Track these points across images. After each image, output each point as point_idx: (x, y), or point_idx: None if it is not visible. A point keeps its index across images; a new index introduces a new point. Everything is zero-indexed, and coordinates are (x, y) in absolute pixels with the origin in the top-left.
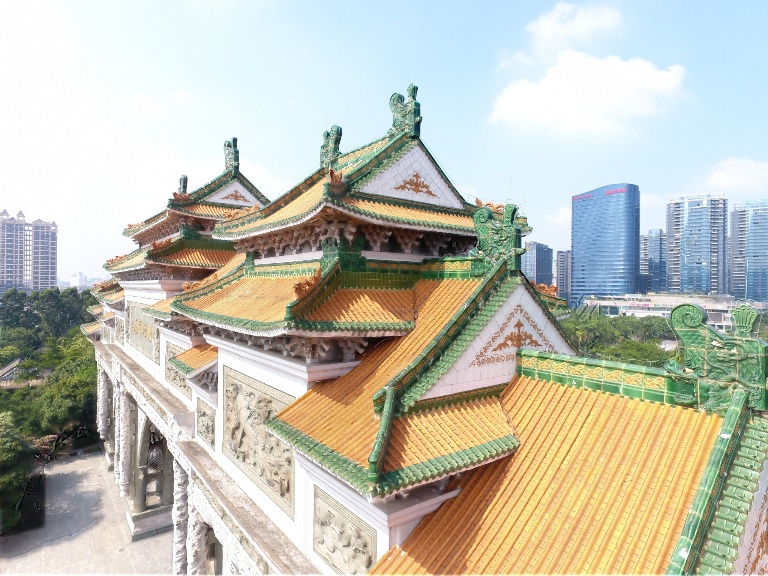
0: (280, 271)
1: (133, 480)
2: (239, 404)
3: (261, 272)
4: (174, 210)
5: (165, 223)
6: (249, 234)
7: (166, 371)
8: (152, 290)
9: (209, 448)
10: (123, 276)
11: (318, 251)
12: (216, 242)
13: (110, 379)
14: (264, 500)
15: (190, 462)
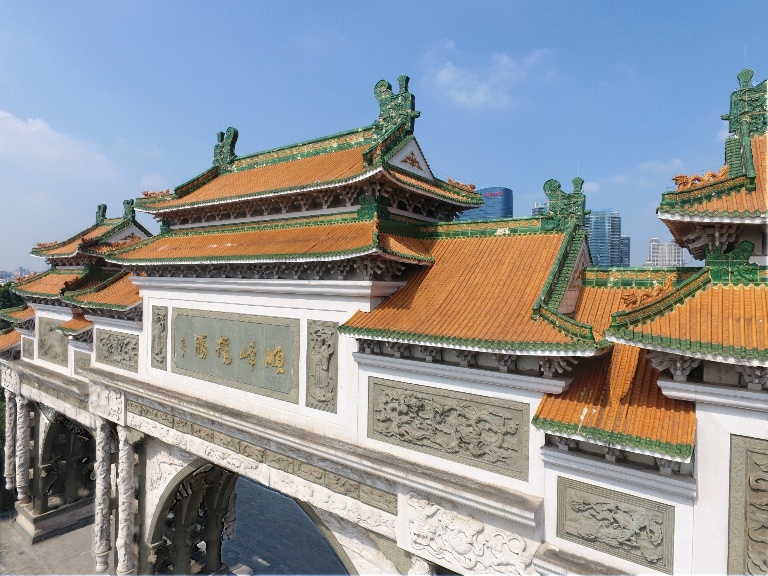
0: None
1: (137, 564)
2: None
3: None
4: (385, 171)
5: (316, 192)
6: None
7: (371, 423)
8: (300, 295)
9: (637, 566)
10: (172, 270)
11: None
12: (403, 225)
13: (74, 418)
14: None
15: None
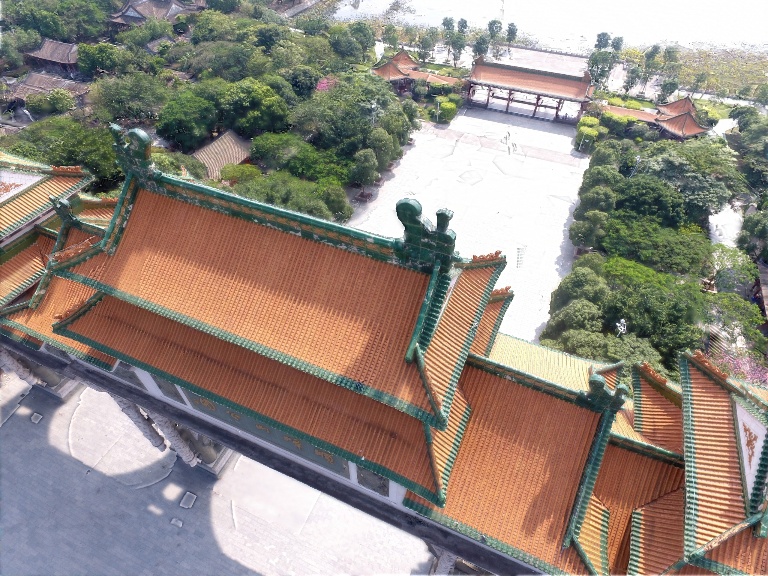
0: None
1: None
2: None
3: None
4: None
5: None
6: None
7: None
8: None
9: None
10: None
11: None
12: None
13: None
14: None
15: None
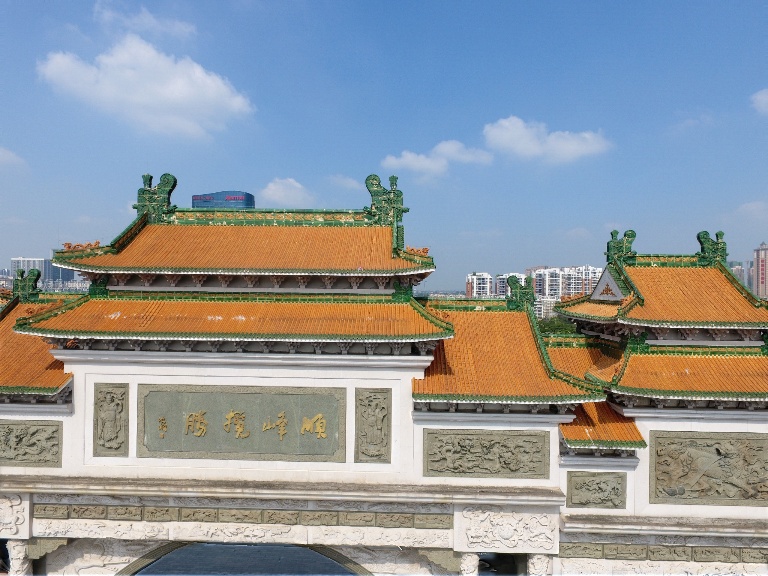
0: (703, 352)
1: None
2: (695, 455)
3: (667, 351)
4: None
5: (355, 276)
6: (697, 326)
7: (426, 465)
8: (350, 367)
9: (610, 510)
10: (157, 344)
11: (756, 341)
12: None
13: None
14: (742, 510)
15: (628, 525)
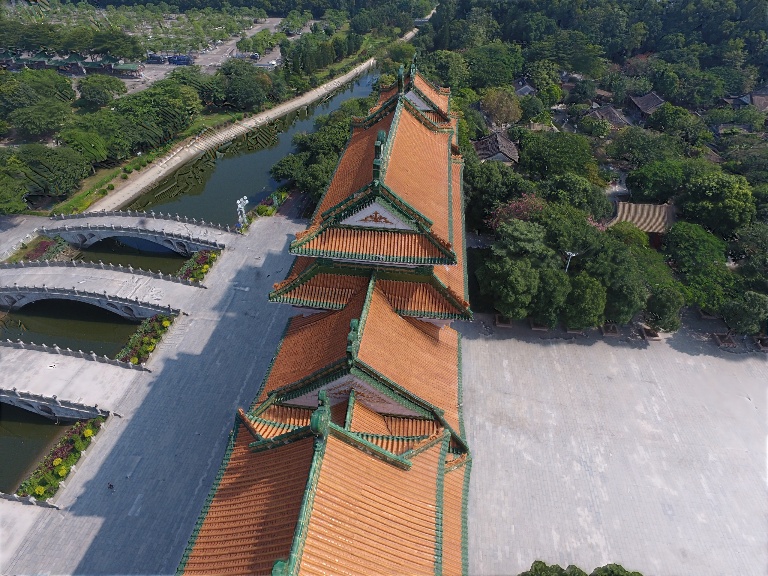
0: None
1: None
2: None
3: None
4: None
5: None
6: None
7: None
8: None
9: None
10: None
11: None
12: None
13: None
14: None
15: None
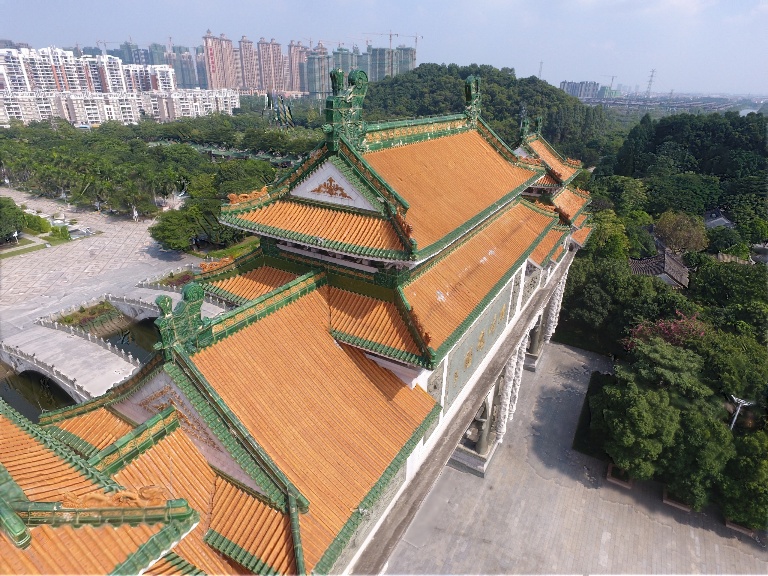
0: None
1: None
2: None
3: None
4: None
5: None
6: None
7: None
8: None
9: None
10: None
11: None
12: None
13: None
14: None
15: None
